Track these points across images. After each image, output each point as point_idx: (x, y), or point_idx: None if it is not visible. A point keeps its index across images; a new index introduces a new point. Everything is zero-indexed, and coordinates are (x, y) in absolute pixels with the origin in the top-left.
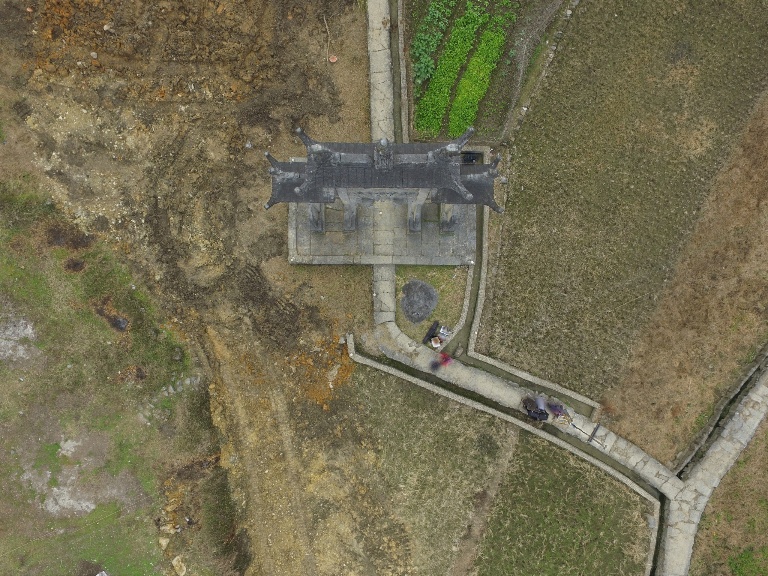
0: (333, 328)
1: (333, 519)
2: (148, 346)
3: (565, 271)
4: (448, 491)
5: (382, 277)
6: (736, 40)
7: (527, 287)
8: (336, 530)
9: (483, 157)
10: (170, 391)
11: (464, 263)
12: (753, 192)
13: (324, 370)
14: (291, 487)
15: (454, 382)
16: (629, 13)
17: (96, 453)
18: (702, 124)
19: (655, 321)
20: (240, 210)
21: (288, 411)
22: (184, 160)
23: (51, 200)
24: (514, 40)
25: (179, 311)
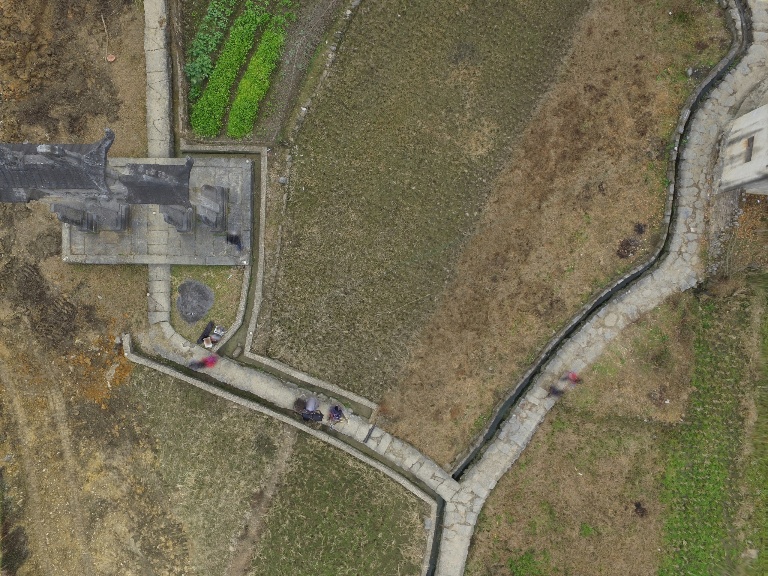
0: (109, 328)
1: (110, 518)
2: None
3: (345, 272)
4: (225, 491)
5: (157, 277)
6: (519, 41)
7: (307, 288)
8: (113, 529)
9: (261, 157)
10: None
11: (238, 263)
12: (534, 194)
13: (102, 369)
14: (69, 486)
15: (228, 382)
16: (411, 13)
17: None
18: (483, 125)
19: (435, 323)
20: (18, 209)
21: (66, 410)
22: None
23: None
24: (295, 40)
25: None
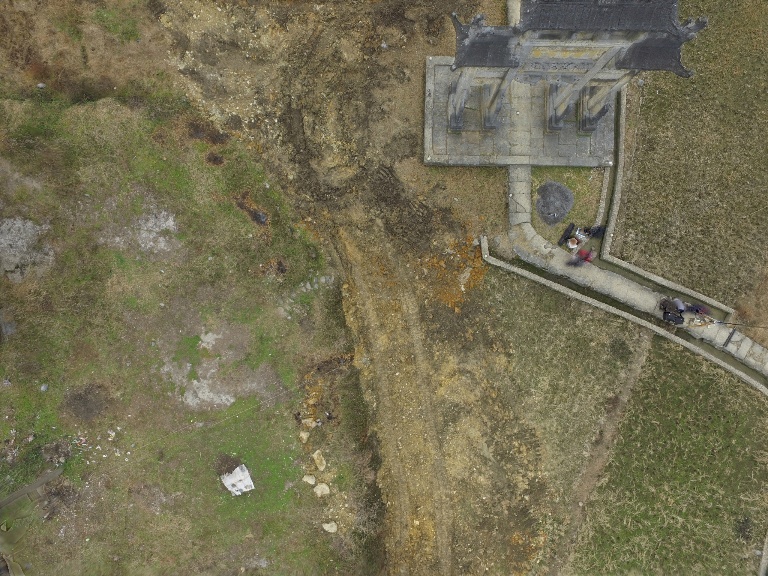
0: (467, 229)
1: (464, 423)
2: (286, 241)
3: (700, 176)
4: (580, 396)
5: (518, 178)
6: None
7: (661, 192)
8: (466, 434)
9: None
10: (307, 287)
11: (601, 164)
12: None
13: (456, 273)
14: (421, 390)
15: (589, 285)
16: None
17: (237, 346)
18: None
19: None
20: (374, 110)
21: (419, 314)
22: (318, 60)
23: (185, 98)
24: None
25: (312, 211)
